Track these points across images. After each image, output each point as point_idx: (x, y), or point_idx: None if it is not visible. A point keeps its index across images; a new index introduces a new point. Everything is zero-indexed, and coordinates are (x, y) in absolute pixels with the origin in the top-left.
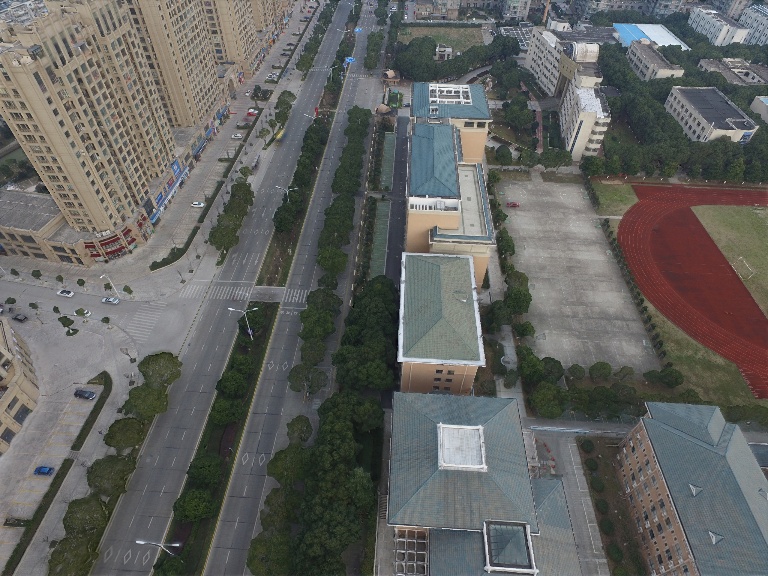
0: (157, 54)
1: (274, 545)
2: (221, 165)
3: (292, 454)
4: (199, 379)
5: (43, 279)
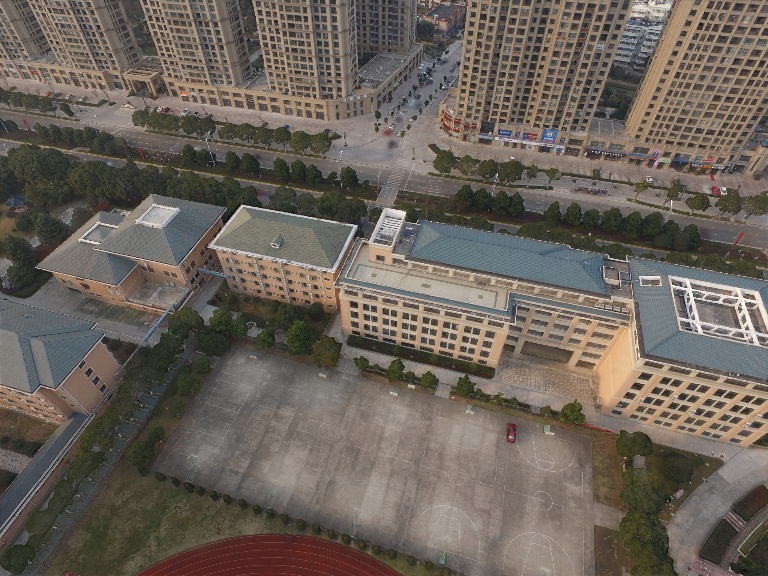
0: (659, 54)
1: (188, 178)
2: (586, 172)
3: (230, 184)
4: (320, 168)
5: (430, 110)
